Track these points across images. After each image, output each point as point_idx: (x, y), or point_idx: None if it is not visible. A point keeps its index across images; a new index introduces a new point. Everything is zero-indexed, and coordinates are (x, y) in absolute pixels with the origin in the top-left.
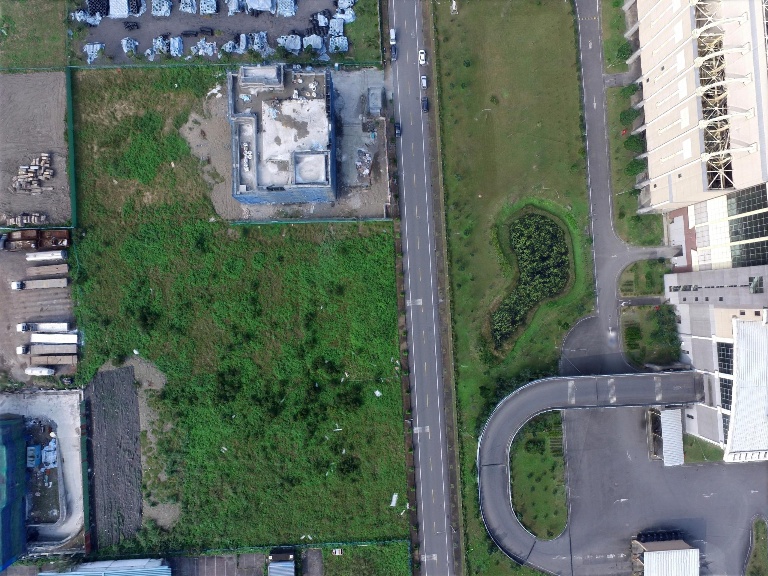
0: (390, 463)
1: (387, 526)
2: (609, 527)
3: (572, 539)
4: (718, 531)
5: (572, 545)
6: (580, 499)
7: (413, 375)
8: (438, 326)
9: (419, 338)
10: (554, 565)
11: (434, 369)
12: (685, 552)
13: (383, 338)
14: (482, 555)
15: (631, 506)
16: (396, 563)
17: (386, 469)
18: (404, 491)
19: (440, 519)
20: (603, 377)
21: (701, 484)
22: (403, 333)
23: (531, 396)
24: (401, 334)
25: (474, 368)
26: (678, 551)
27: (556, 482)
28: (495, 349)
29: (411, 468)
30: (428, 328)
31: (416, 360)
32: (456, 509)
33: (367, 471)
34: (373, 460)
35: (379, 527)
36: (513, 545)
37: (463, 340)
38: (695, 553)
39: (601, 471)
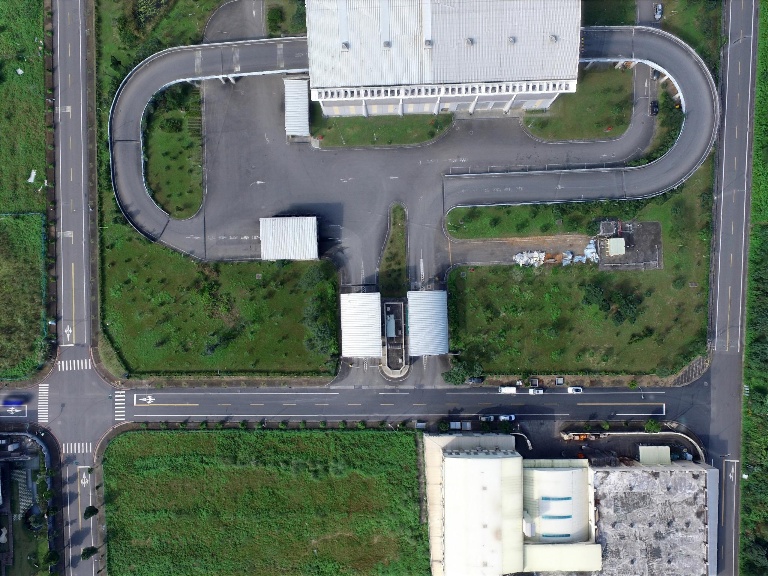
0: (28, 139)
1: (22, 200)
2: (244, 209)
3: (206, 220)
4: (355, 216)
5: (206, 225)
6: (216, 180)
7: (57, 56)
8: (84, 8)
9: (64, 20)
10: (187, 244)
11: (78, 50)
12: (301, 220)
13: (26, 17)
14: (116, 232)
15: (267, 189)
16: (31, 237)
17: (24, 145)
18: (42, 168)
19: (77, 197)
20: (228, 46)
21: (339, 168)
22: (46, 13)
23: (160, 68)
24: (46, 15)
25: (116, 49)
26: (294, 218)
27: (192, 162)
28: (136, 29)
29: (50, 145)
30: (73, 10)
31: (60, 41)
32: (94, 188)
33: (5, 146)
34: (12, 136)
35: (15, 201)
36: (146, 222)
37: (107, 22)
38: (312, 221)
39: (238, 153)
